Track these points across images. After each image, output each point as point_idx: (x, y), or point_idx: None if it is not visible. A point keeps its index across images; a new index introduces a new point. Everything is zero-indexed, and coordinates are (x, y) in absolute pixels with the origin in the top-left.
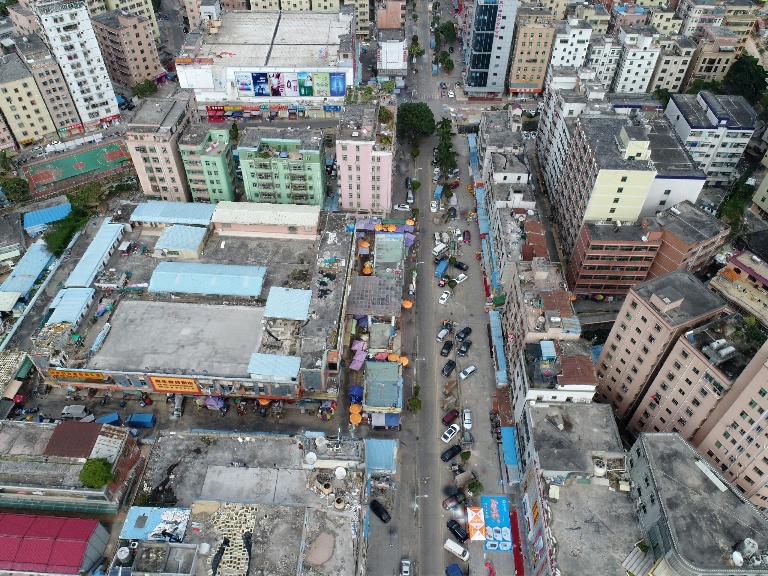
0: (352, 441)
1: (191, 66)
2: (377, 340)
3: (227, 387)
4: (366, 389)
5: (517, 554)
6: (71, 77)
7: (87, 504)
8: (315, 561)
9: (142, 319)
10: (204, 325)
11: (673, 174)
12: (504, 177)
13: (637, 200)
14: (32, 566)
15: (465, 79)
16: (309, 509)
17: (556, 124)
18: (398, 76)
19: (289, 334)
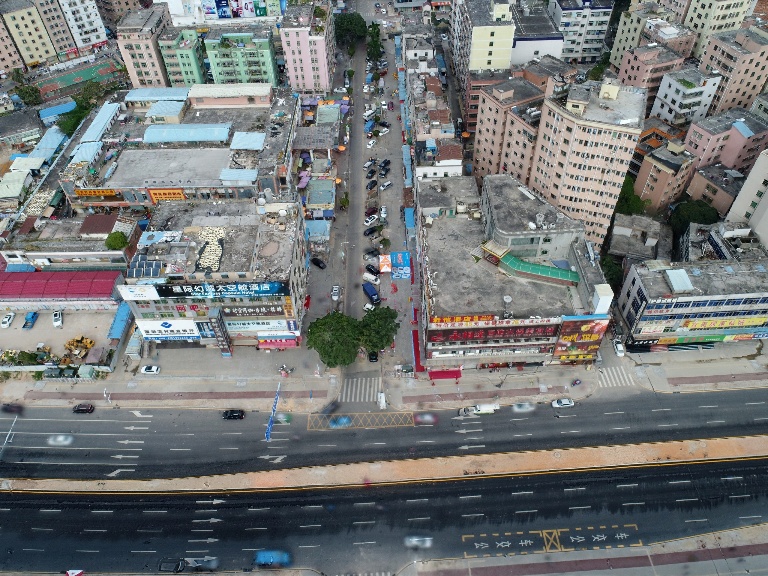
0: (290, 193)
1: None
2: (318, 169)
3: (206, 195)
4: (309, 196)
5: (413, 279)
6: (66, 7)
7: (112, 266)
8: (266, 254)
9: (140, 160)
10: (187, 160)
11: (538, 37)
12: (415, 54)
13: (506, 52)
14: (78, 295)
15: None
16: (262, 232)
17: (456, 13)
18: None
19: (250, 162)
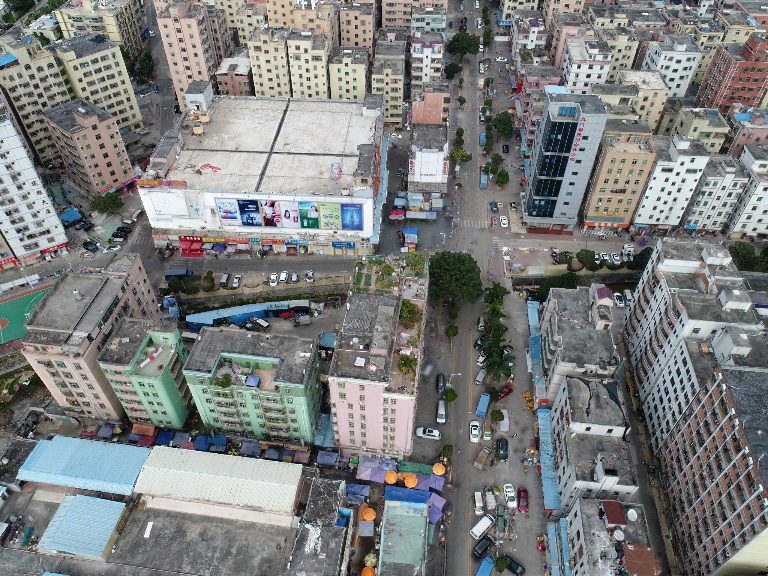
0: None
1: (158, 189)
2: None
3: None
4: None
5: None
6: None
7: None
8: None
9: None
10: None
11: None
12: (587, 427)
13: None
14: None
15: (524, 202)
16: None
17: (668, 336)
18: (435, 192)
19: None
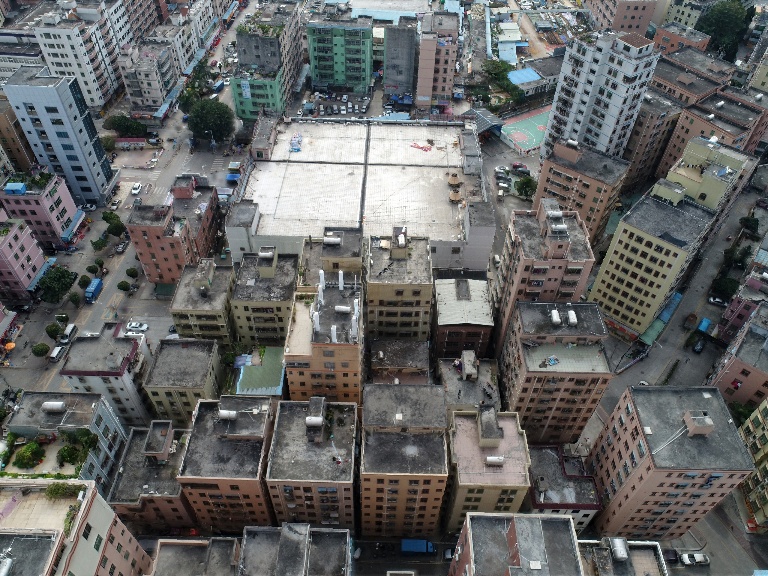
0: None
1: (457, 122)
2: None
3: None
4: (302, 4)
5: None
6: None
7: None
8: None
9: None
10: None
11: None
12: None
13: None
14: None
15: None
16: None
17: None
18: None
19: None
